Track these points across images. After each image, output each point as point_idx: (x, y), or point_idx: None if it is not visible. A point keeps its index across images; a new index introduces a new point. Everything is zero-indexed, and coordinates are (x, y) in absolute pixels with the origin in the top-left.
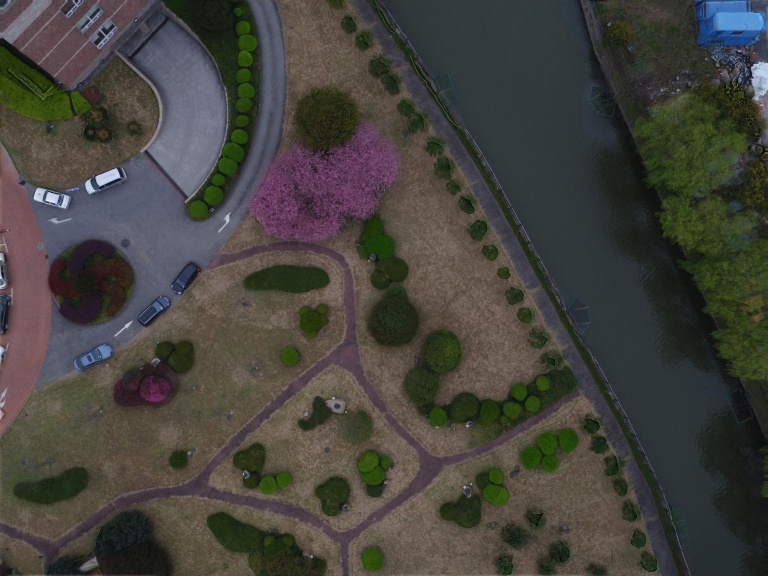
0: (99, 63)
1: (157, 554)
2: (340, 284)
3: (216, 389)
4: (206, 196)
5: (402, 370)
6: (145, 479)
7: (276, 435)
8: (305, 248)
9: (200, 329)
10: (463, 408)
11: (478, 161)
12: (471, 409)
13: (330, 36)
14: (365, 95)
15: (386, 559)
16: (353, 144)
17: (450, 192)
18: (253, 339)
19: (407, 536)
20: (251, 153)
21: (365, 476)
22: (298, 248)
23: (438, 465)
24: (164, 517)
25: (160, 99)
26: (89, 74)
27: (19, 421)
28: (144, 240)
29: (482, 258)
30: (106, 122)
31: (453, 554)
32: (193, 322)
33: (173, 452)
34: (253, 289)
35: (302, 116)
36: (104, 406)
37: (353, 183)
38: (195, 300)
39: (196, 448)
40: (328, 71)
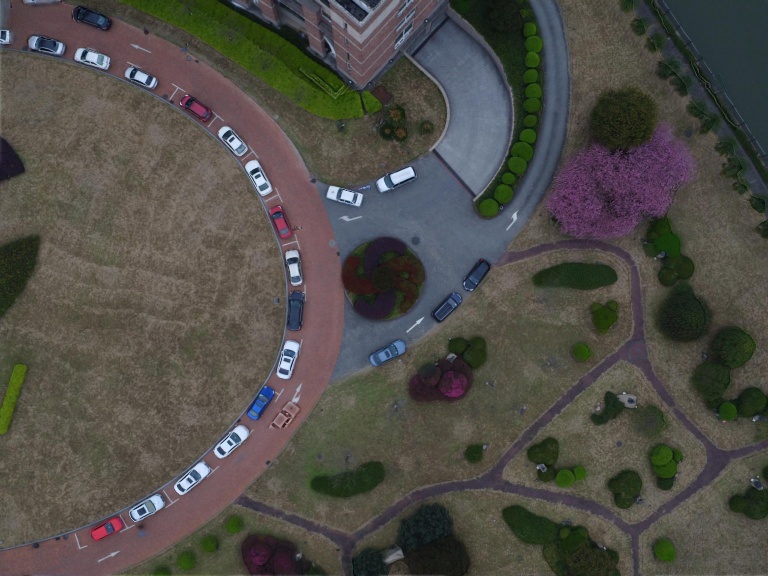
0: (387, 63)
1: (460, 546)
2: (627, 281)
3: (509, 384)
4: (498, 194)
5: (689, 365)
6: (440, 473)
7: (568, 429)
8: (592, 246)
9: (491, 325)
10: (753, 403)
11: (757, 161)
12: (761, 403)
13: (612, 38)
14: (647, 96)
15: (676, 550)
16: (652, 144)
17: (738, 191)
18: (543, 335)
19: (696, 528)
20: (537, 152)
21: (660, 469)
22: (585, 246)
23: (725, 458)
24: (459, 510)
25: (447, 99)
26: (377, 74)
27: (314, 416)
28: (434, 238)
29: (763, 256)
30: (403, 121)
31: (740, 545)
32: (483, 318)
33: (468, 446)
34: (543, 286)
35: (587, 116)
36: (398, 401)
37: (653, 182)
38: (485, 297)
39: (490, 442)
40: (611, 72)
